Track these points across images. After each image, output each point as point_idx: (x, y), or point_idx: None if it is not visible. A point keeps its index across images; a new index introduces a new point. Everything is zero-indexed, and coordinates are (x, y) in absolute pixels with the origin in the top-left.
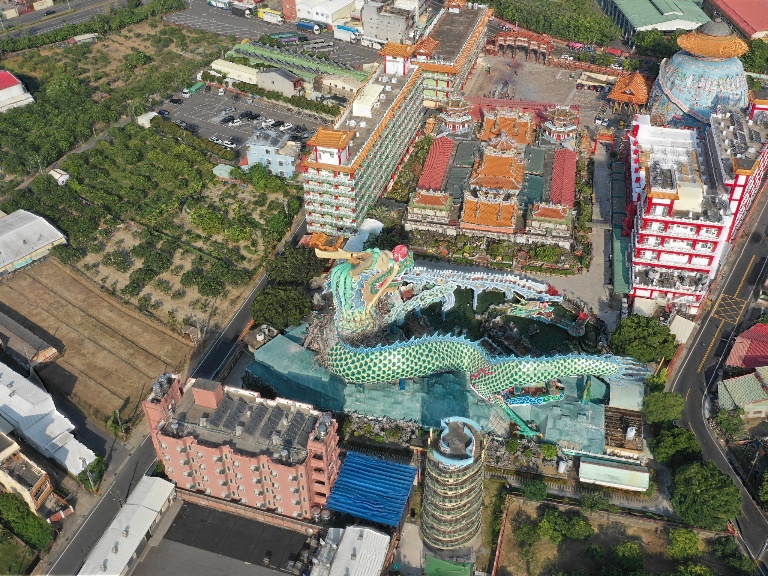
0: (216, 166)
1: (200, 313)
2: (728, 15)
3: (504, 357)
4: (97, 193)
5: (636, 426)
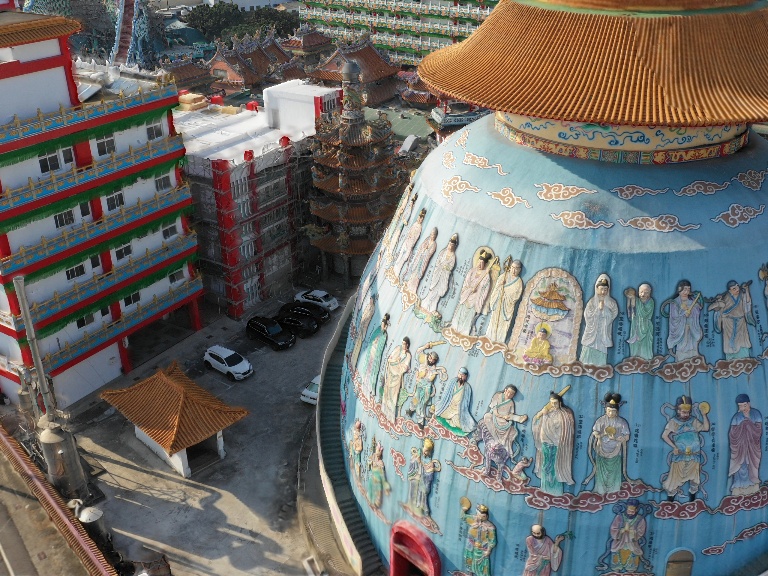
0: None
1: None
2: None
3: None
4: None
5: None
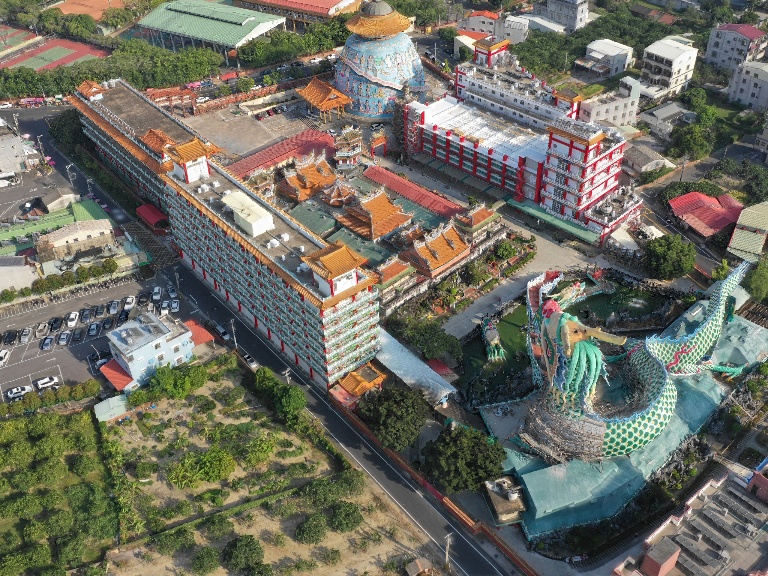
0: (95, 411)
1: (379, 548)
2: (283, 6)
3: (703, 325)
4: (6, 565)
5: (764, 310)
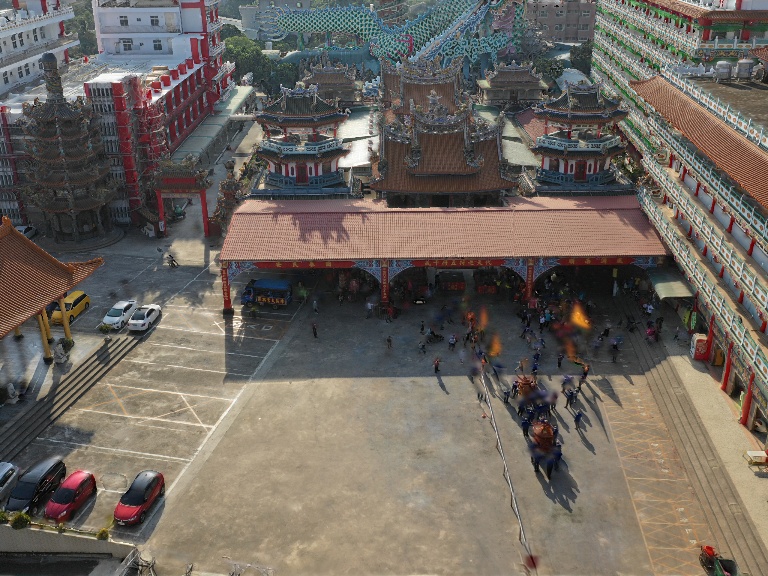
0: None
1: None
2: None
3: None
4: None
5: None
